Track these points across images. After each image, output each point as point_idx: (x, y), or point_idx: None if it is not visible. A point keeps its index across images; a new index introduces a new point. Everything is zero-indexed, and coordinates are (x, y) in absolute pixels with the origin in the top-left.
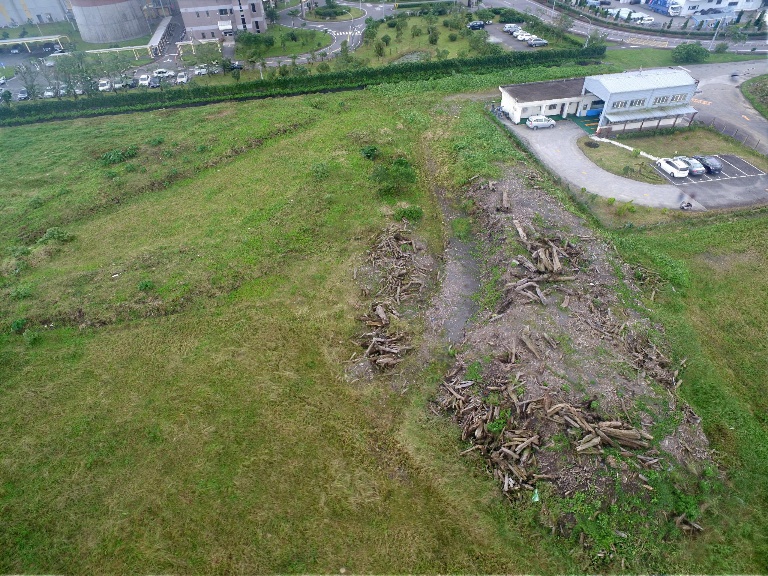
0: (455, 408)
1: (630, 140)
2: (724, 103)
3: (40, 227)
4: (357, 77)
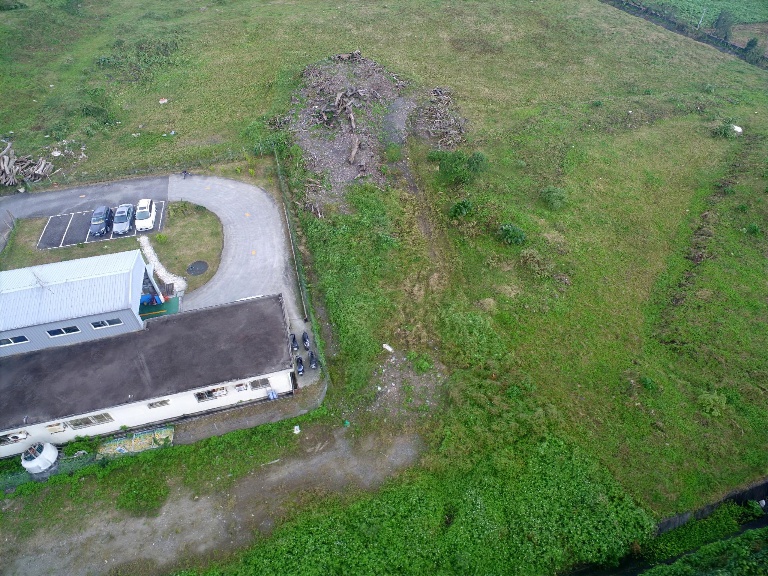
0: None
1: None
2: None
3: (761, 142)
4: None
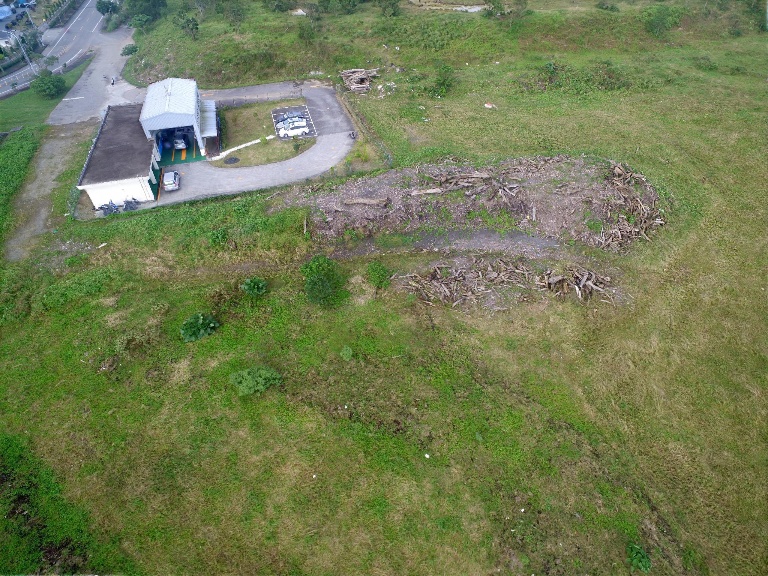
0: None
1: (230, 142)
2: None
3: None
4: None
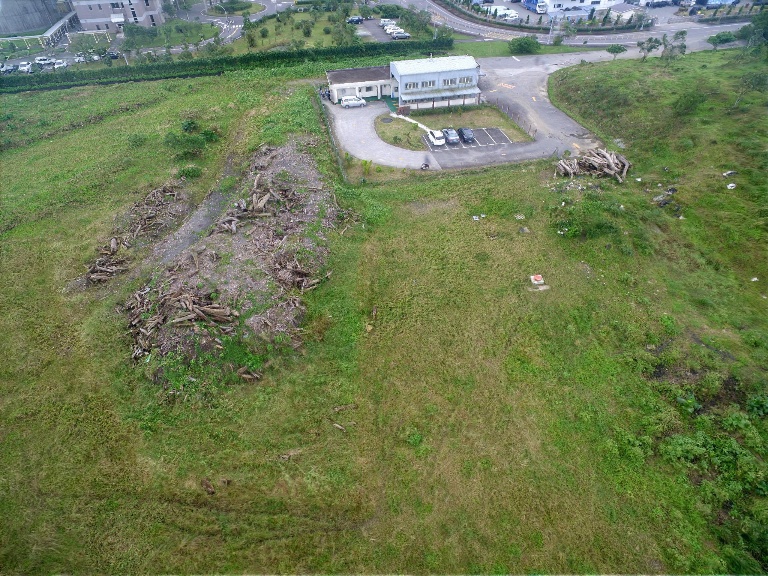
0: (134, 308)
1: (422, 117)
2: (526, 87)
3: None
4: (217, 64)
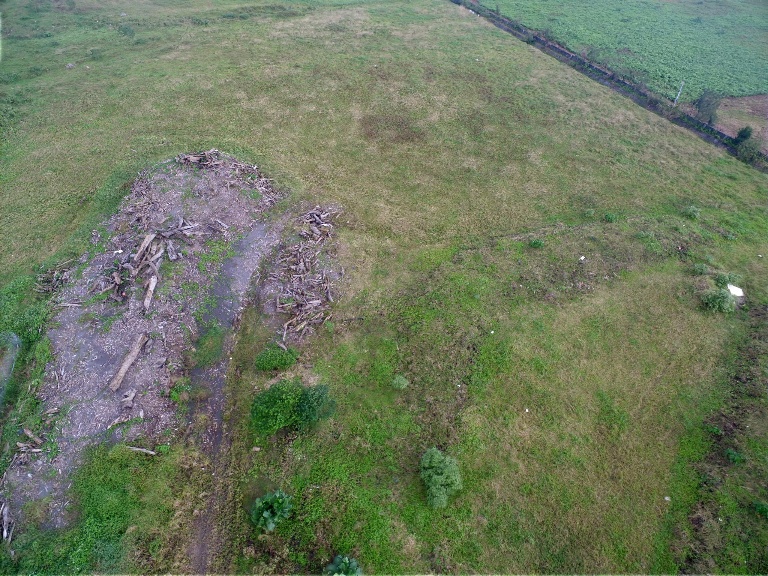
0: None
1: None
2: None
3: None
4: None
